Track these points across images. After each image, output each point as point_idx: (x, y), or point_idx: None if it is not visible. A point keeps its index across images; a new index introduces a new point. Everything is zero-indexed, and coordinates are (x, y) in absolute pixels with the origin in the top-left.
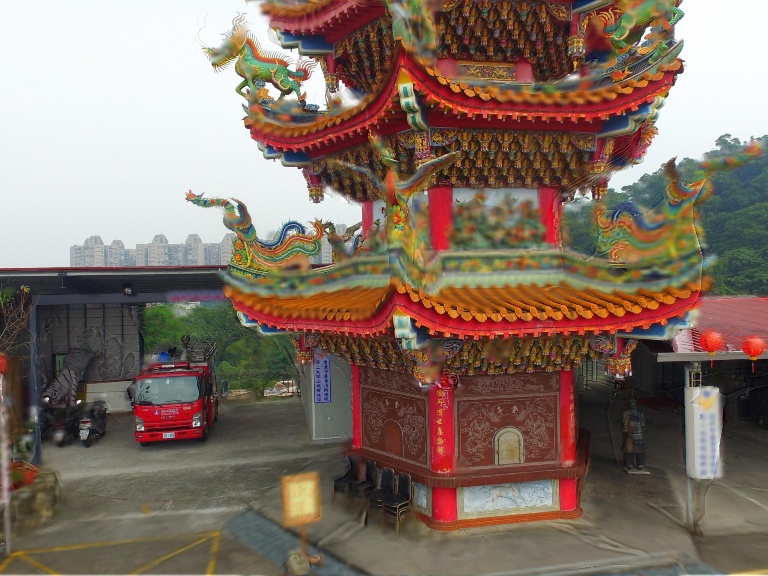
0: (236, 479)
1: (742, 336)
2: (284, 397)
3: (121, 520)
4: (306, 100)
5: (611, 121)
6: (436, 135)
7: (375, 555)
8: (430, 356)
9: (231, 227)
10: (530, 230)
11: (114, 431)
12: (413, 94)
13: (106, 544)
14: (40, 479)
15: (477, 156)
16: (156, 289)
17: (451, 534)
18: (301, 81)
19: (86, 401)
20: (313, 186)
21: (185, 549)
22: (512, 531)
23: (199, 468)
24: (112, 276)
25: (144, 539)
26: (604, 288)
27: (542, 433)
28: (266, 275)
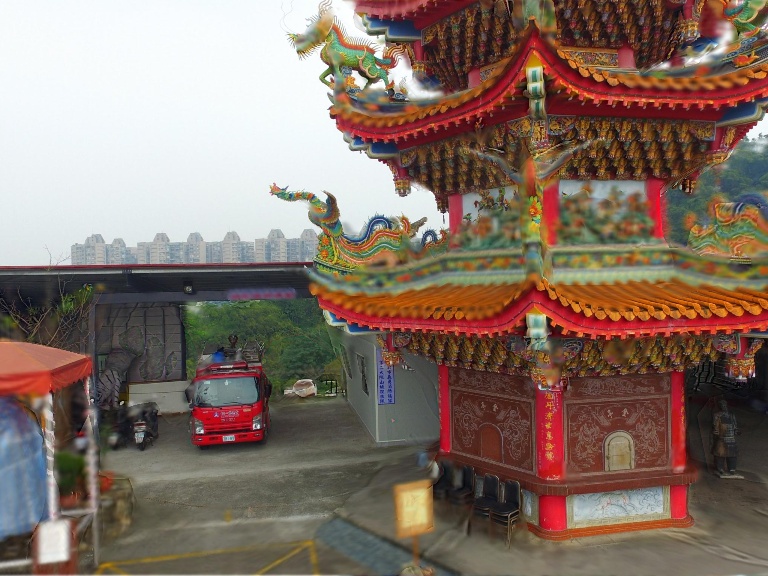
0: (309, 484)
1: None
2: (327, 398)
3: (204, 529)
4: (394, 89)
5: (739, 108)
6: (553, 123)
7: (491, 567)
8: (551, 357)
9: (317, 222)
10: (639, 224)
11: (167, 434)
12: (542, 78)
13: (196, 555)
14: (117, 486)
15: (591, 146)
16: (217, 287)
17: (564, 544)
18: (388, 69)
19: (129, 402)
20: (400, 179)
21: (282, 560)
22: (627, 541)
23: (266, 472)
24: (177, 274)
25: (235, 549)
26: (724, 285)
27: (653, 437)
28: (353, 272)
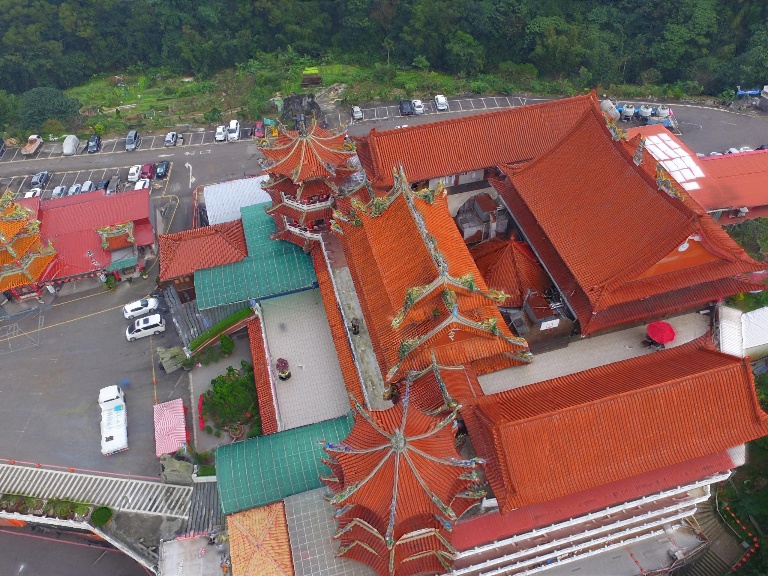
0: None
1: (66, 264)
2: None
3: None
4: None
5: None
6: None
7: (8, 307)
8: None
9: None
10: None
11: None
12: None
13: None
14: None
15: None
16: None
17: (20, 301)
18: None
19: None
20: None
21: None
22: None
23: None
24: None
25: None
26: None
27: None
28: None
